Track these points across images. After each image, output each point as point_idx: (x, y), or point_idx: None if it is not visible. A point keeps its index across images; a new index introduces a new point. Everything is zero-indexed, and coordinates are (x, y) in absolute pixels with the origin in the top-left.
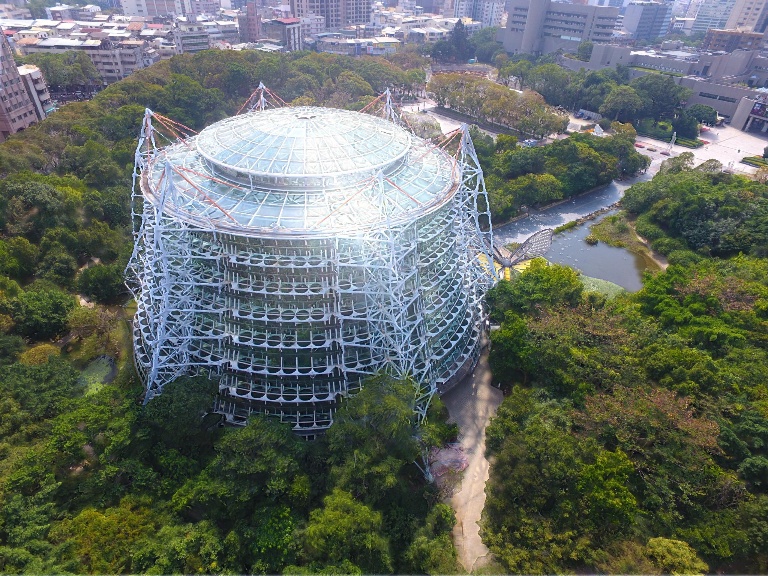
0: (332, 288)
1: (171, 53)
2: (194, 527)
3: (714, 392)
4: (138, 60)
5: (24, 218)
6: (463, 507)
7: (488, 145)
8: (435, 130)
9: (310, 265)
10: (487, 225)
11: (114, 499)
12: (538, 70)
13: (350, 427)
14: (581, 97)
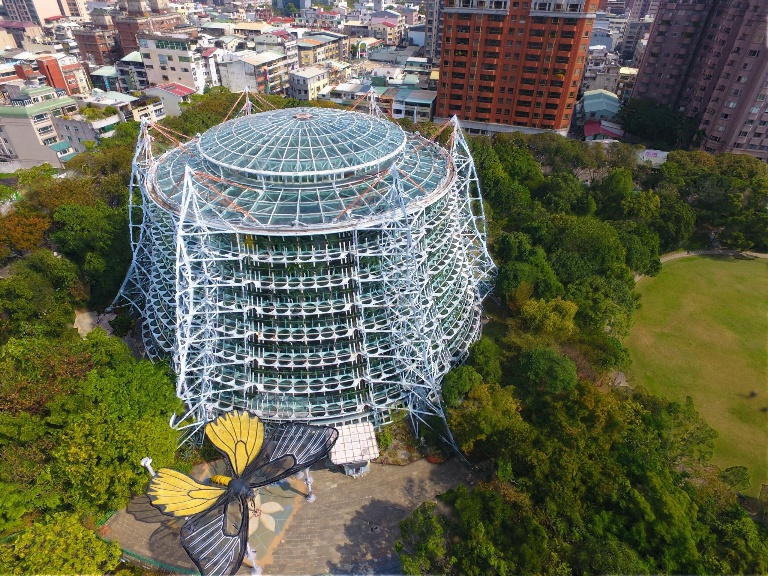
0: None
1: None
2: None
3: None
4: None
5: None
6: (79, 319)
7: None
8: None
9: None
10: None
11: None
12: None
13: None
14: None
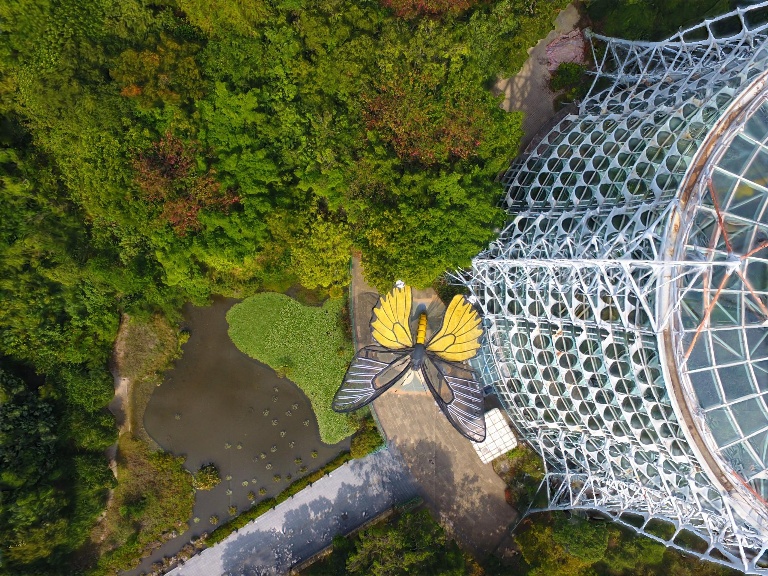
0: None
1: None
2: None
3: None
4: None
5: None
6: None
7: None
8: None
9: None
10: None
11: None
12: None
13: None
14: None
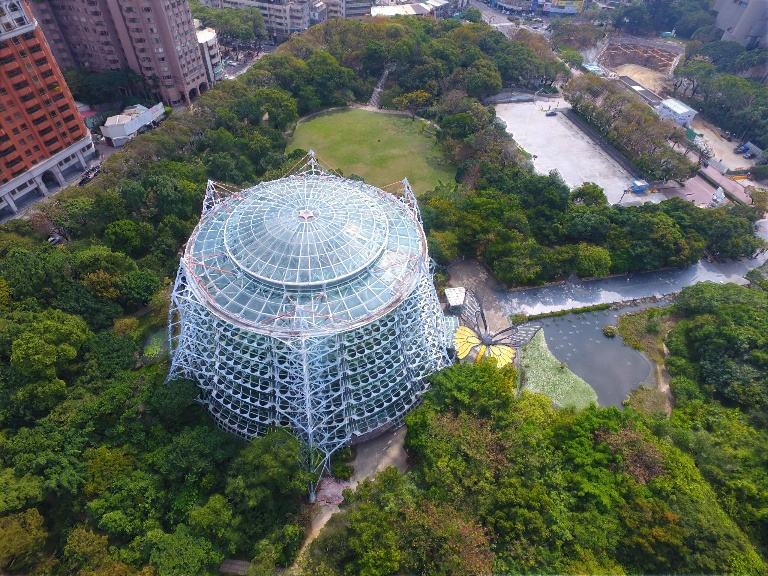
0: (273, 360)
1: (338, 4)
2: (151, 477)
3: (534, 540)
4: (304, 15)
5: (154, 203)
6: None
7: (563, 195)
8: (518, 165)
9: (256, 345)
10: (513, 285)
11: (121, 443)
12: (717, 80)
13: (247, 458)
14: (754, 128)
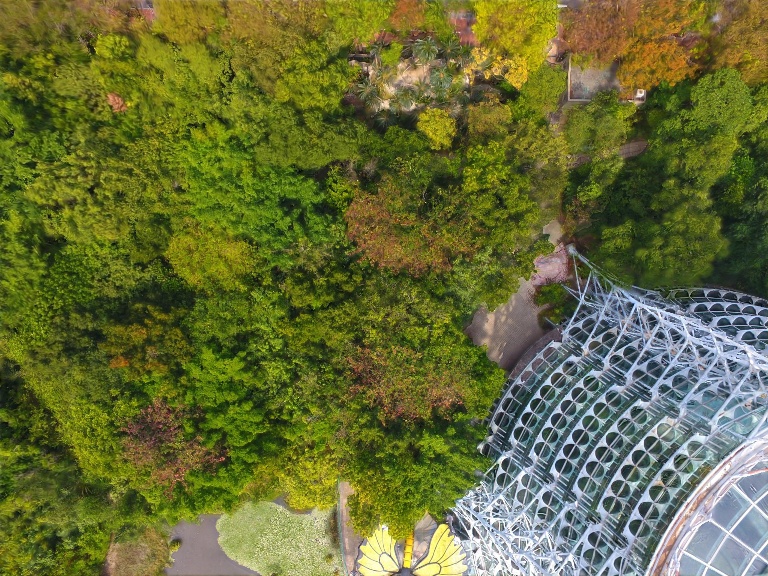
0: None
1: None
2: None
3: None
4: None
5: None
6: None
7: None
8: None
9: None
10: None
11: None
12: None
13: None
14: None
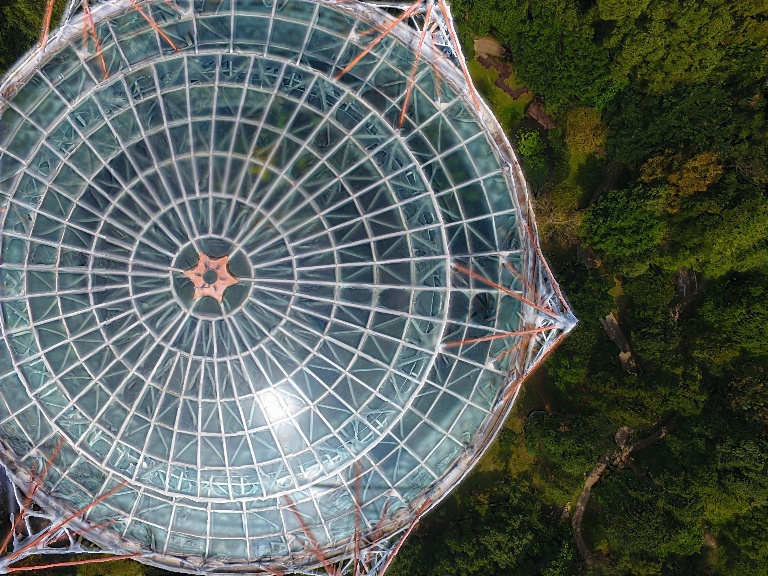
0: None
1: None
2: None
3: None
4: None
5: None
6: None
7: None
8: None
9: None
10: None
11: None
12: None
13: None
14: None
